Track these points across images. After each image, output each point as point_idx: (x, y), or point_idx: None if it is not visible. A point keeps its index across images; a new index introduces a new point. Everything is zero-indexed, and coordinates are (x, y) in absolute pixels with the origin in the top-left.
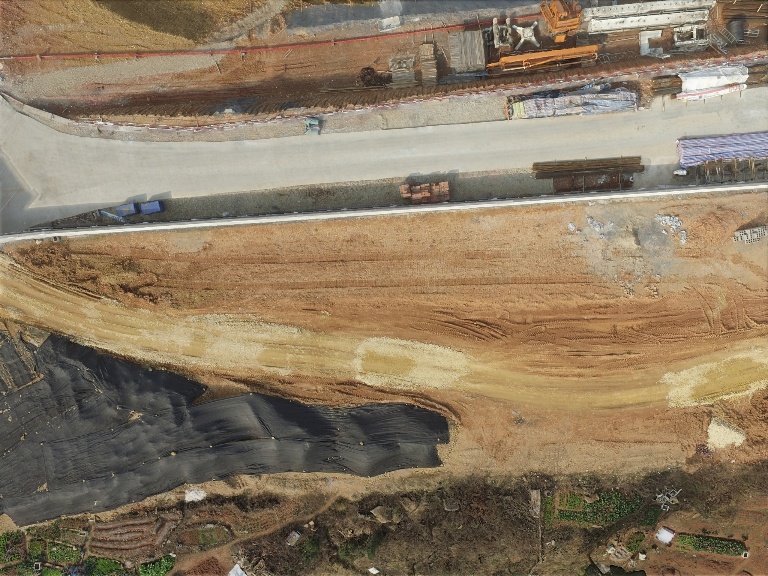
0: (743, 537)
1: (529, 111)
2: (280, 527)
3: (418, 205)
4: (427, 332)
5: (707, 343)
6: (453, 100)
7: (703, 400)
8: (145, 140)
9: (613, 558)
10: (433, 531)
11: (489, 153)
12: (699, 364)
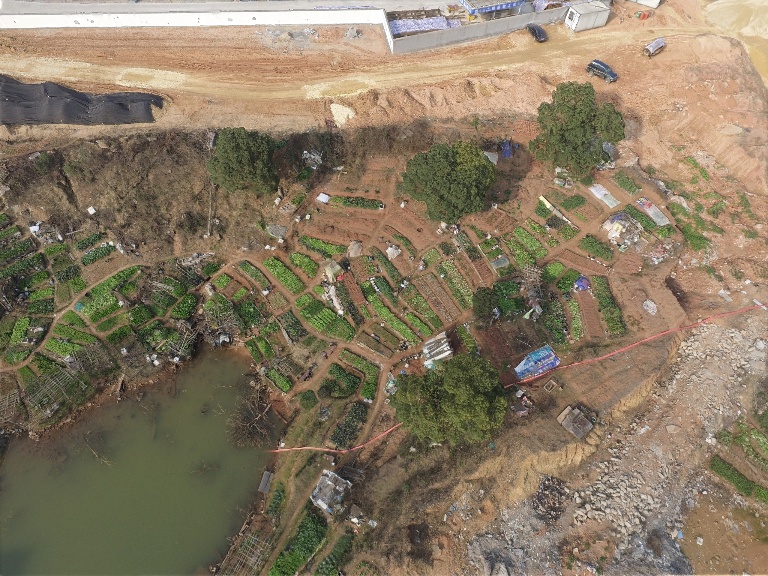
0: (376, 191)
1: None
2: None
3: (171, 12)
4: (166, 66)
5: (330, 73)
6: None
7: (327, 95)
8: (48, 2)
9: (281, 210)
10: (137, 157)
11: None
12: (326, 82)
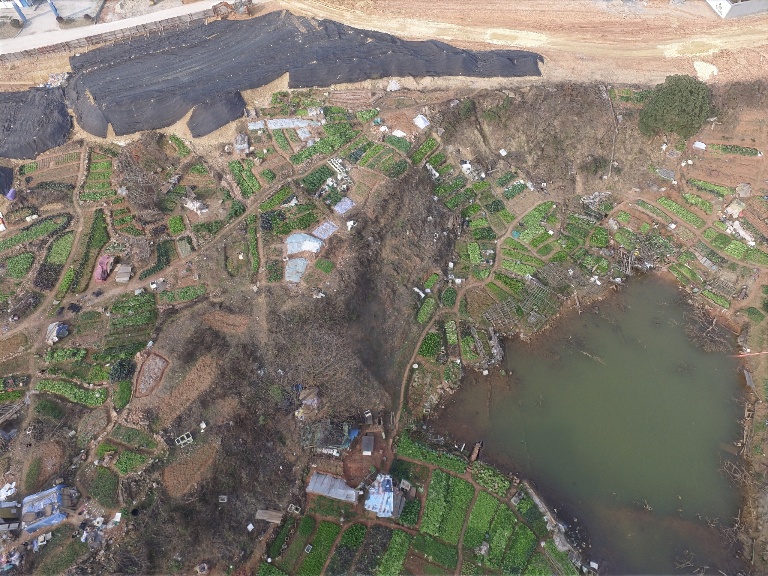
0: (752, 140)
1: None
2: (446, 100)
3: None
4: (523, 28)
5: (676, 35)
6: None
7: None
8: None
9: (668, 155)
10: (542, 105)
11: None
12: (675, 43)
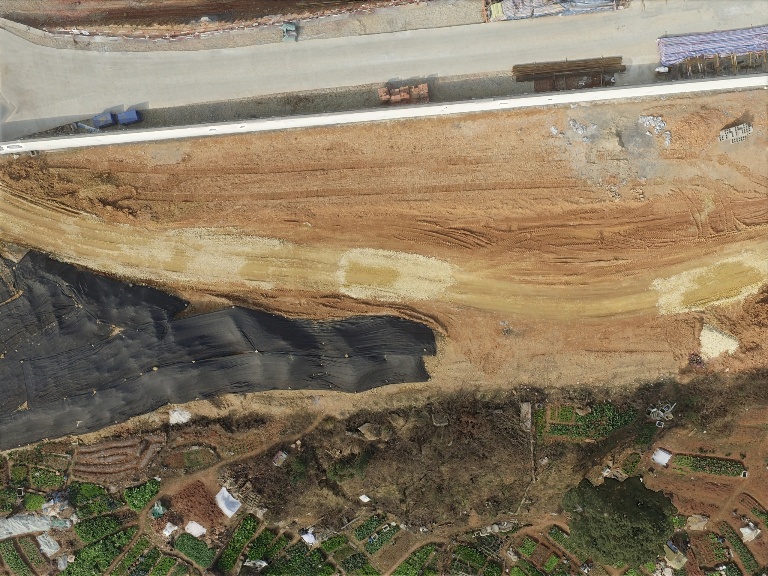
0: (741, 455)
1: (507, 11)
2: (266, 448)
3: (397, 105)
4: (411, 242)
5: (696, 247)
6: (430, 3)
7: (694, 306)
8: (121, 50)
9: None
10: (423, 449)
11: (468, 56)
12: (688, 269)
